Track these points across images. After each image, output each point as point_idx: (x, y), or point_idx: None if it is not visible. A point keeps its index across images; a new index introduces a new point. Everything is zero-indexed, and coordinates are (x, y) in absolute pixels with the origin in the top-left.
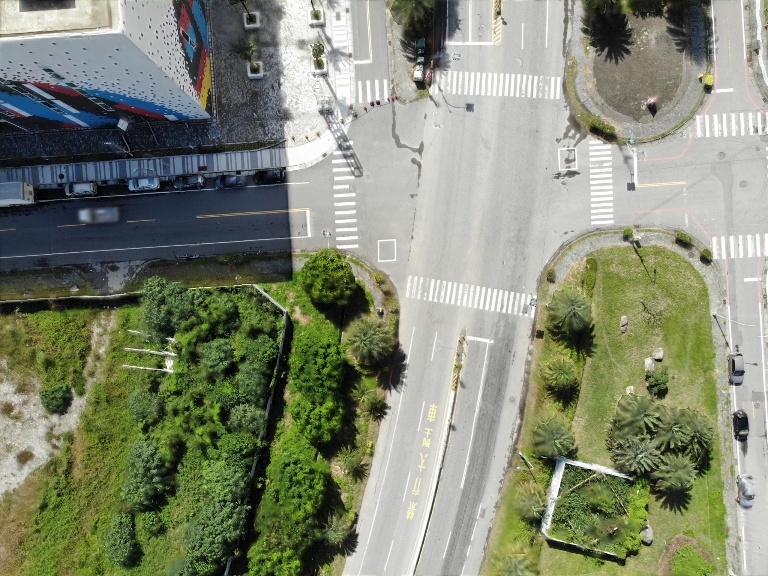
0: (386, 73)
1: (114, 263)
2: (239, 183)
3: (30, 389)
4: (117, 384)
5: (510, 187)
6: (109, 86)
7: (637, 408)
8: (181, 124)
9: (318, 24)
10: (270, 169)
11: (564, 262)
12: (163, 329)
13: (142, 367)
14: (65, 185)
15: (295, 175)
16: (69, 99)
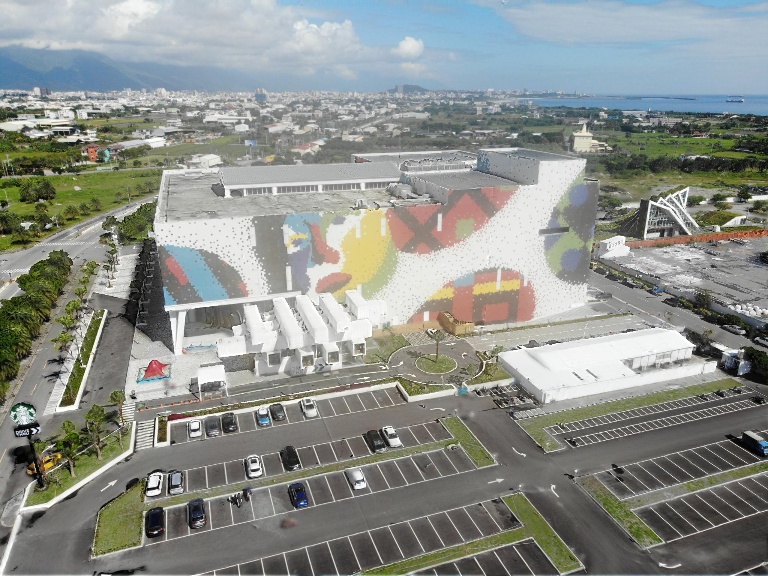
0: None
1: None
2: None
3: None
4: None
5: (33, 257)
6: None
7: (7, 218)
8: None
9: None
10: (150, 252)
11: (17, 250)
12: None
13: None
14: None
15: None
16: None
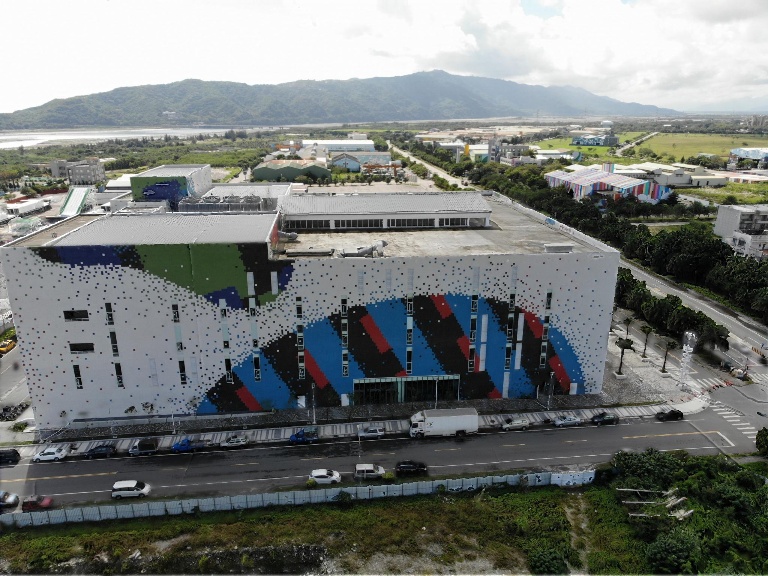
0: (713, 376)
1: (563, 466)
2: (646, 421)
3: (512, 564)
4: (620, 550)
5: None
6: (568, 324)
7: None
8: (579, 396)
9: (647, 361)
10: None
11: None
12: (656, 481)
13: (651, 516)
14: (498, 424)
15: (689, 417)
16: (529, 343)
